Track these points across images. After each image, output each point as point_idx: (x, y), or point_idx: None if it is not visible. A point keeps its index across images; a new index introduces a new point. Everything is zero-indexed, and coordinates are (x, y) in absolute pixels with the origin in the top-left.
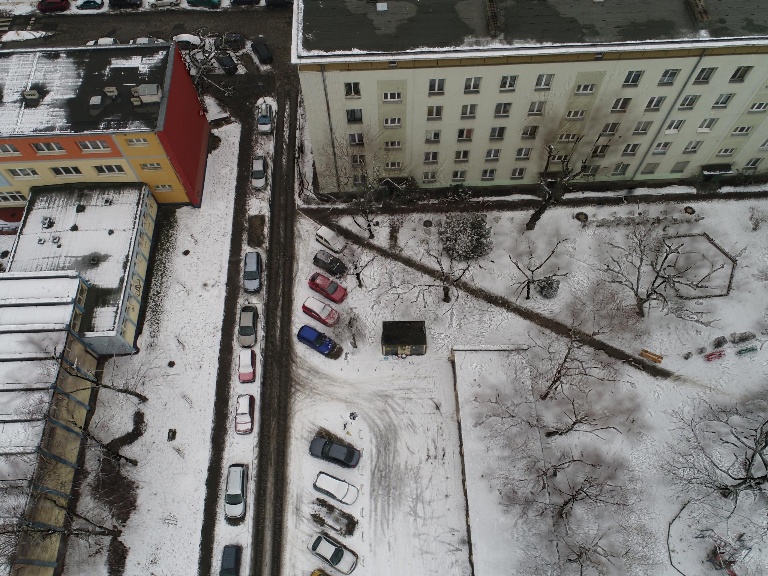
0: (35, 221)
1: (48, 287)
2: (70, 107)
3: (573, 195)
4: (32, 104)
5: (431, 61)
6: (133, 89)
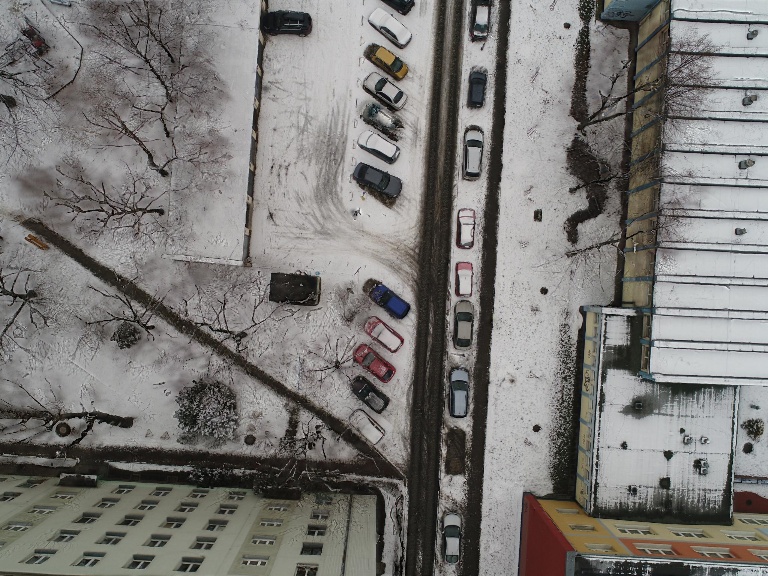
0: (718, 472)
1: (684, 364)
2: None
3: (65, 463)
4: None
5: None
6: None
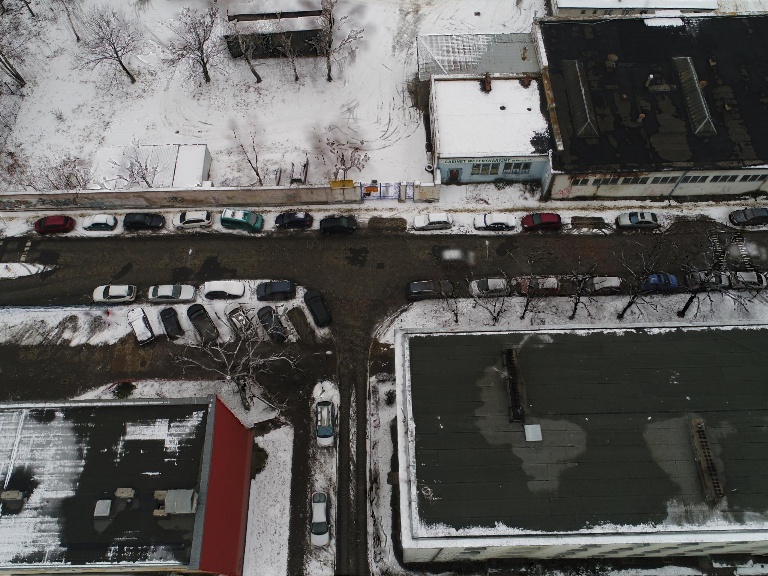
0: None
1: None
2: (66, 515)
3: (749, 570)
4: (13, 507)
5: None
6: (157, 494)
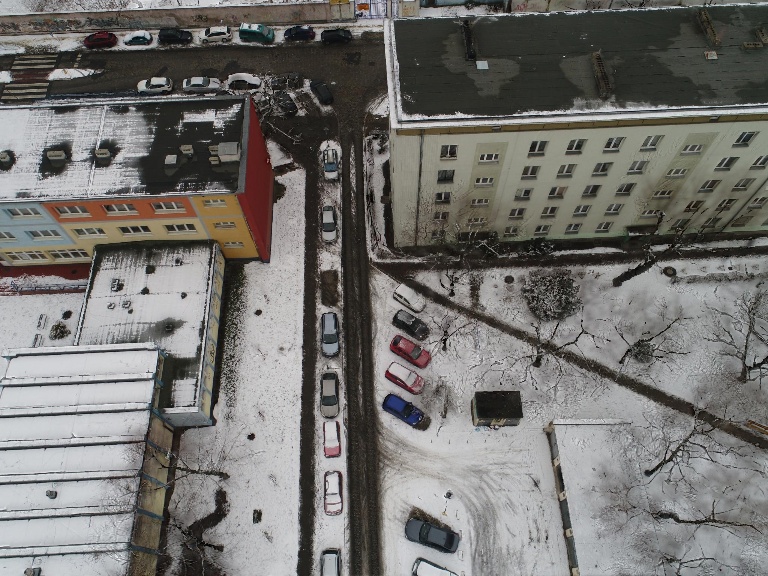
0: (103, 283)
1: (126, 361)
2: (144, 166)
3: (659, 248)
4: (103, 163)
5: (538, 125)
6: (211, 147)
